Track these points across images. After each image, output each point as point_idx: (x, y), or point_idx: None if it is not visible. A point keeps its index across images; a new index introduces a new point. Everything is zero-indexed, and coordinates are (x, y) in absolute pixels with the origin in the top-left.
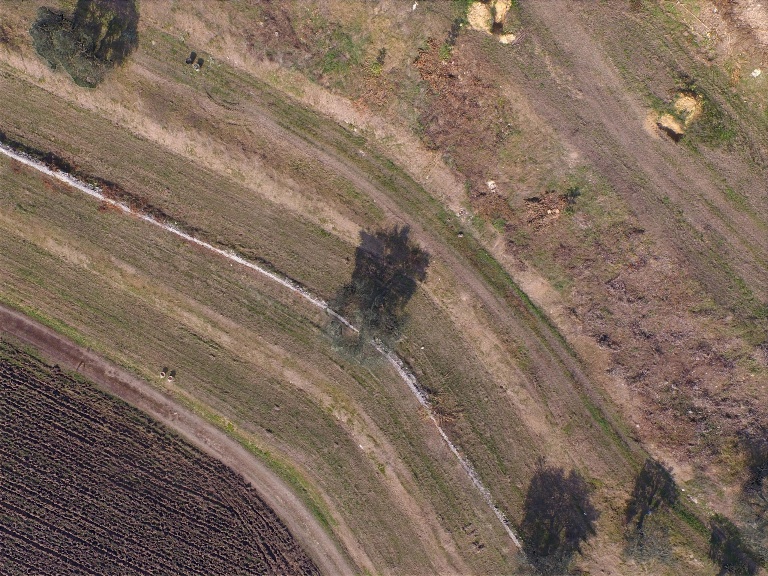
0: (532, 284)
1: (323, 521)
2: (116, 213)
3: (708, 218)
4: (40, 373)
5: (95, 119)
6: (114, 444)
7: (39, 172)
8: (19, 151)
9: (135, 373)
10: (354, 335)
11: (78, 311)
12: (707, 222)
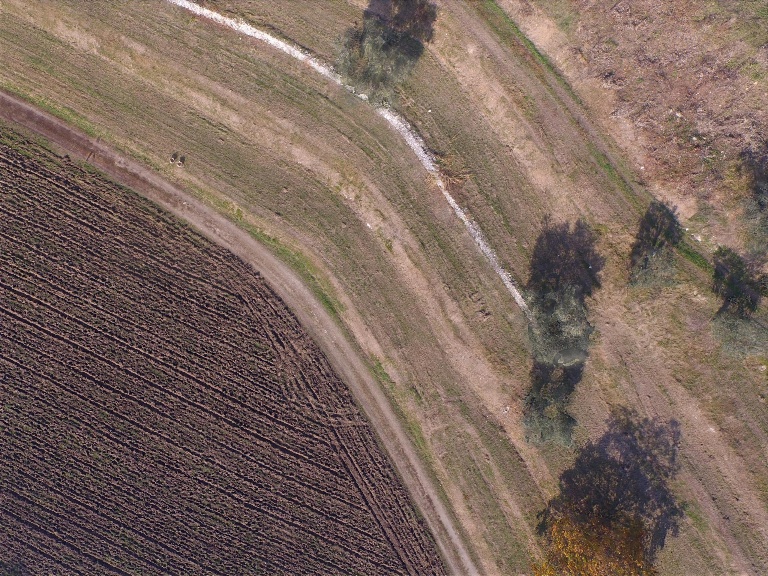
0: (538, 29)
1: (331, 309)
2: None
3: None
4: (50, 163)
5: None
6: (124, 233)
7: None
8: None
9: (144, 163)
10: (362, 105)
11: (88, 99)
12: None
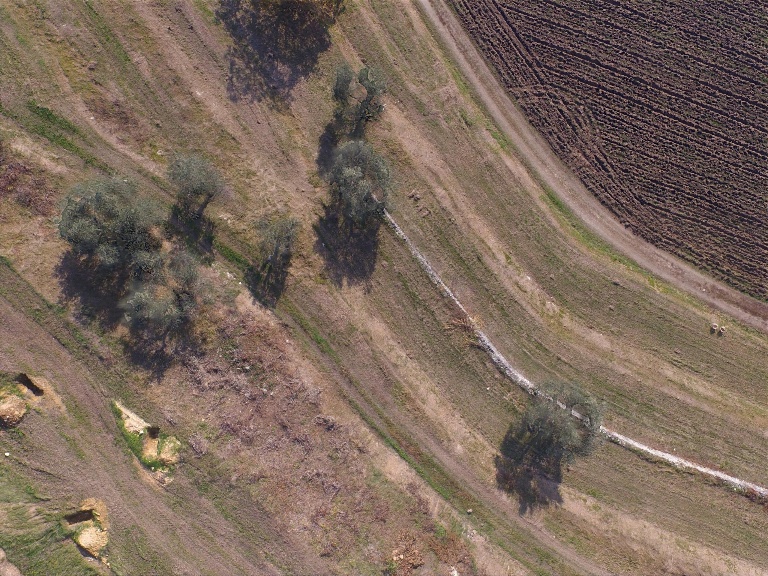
0: (399, 471)
1: (553, 198)
2: None
3: (262, 575)
4: None
5: None
6: (761, 256)
7: None
8: None
9: (747, 327)
10: None
11: None
12: (263, 572)
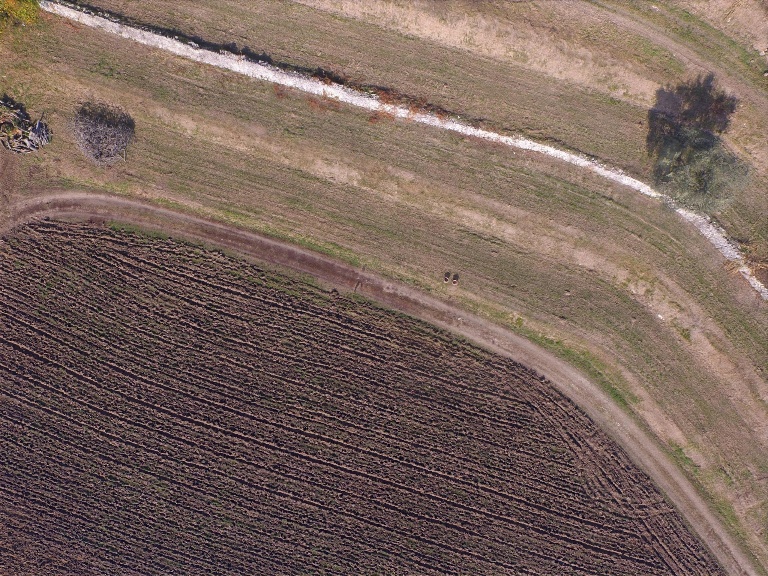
0: None
1: (621, 402)
2: (388, 121)
3: None
4: (319, 300)
5: (361, 27)
6: (404, 358)
7: (304, 93)
8: (289, 71)
9: (414, 285)
10: (650, 201)
11: (350, 231)
12: None
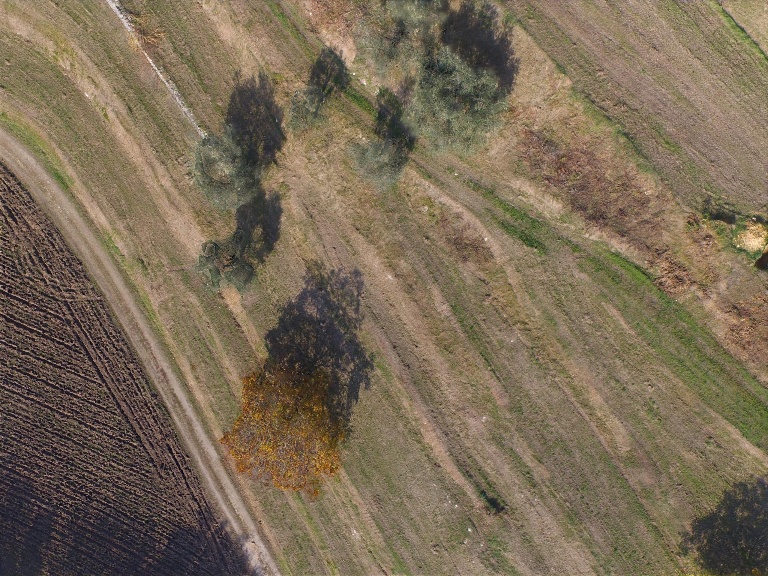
0: None
1: (63, 184)
2: None
3: None
4: None
5: None
6: None
7: None
8: None
9: None
10: None
11: None
12: None
